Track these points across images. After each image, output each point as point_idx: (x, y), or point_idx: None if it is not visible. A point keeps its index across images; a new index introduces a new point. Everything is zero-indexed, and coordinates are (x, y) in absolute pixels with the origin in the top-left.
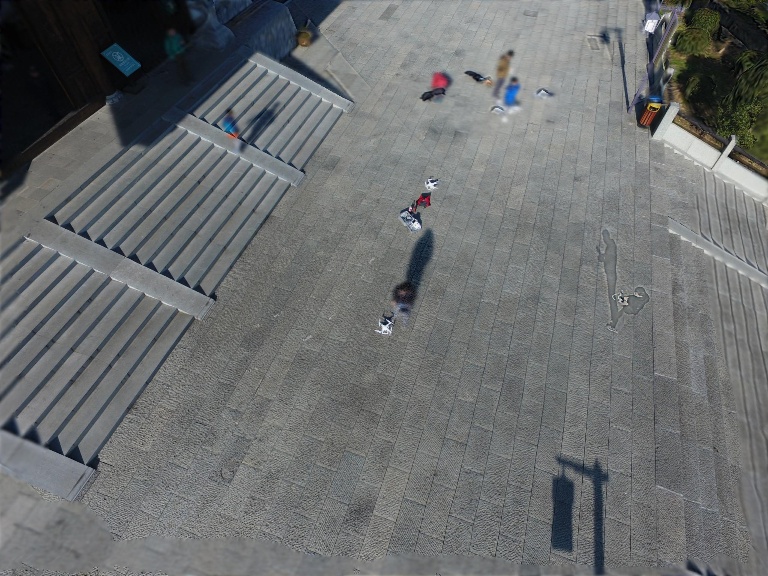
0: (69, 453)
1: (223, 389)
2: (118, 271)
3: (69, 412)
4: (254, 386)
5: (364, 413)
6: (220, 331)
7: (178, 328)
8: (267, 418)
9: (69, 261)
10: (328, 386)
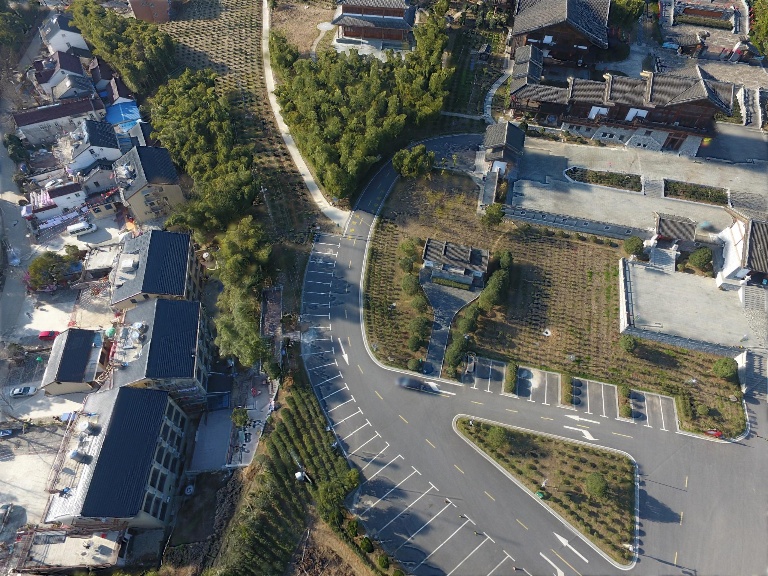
0: (746, 305)
1: (759, 316)
2: (766, 301)
3: (749, 303)
4: (762, 319)
5: (766, 330)
6: (765, 314)
7: (763, 310)
8: (759, 321)
9: (765, 296)
10: (767, 326)
